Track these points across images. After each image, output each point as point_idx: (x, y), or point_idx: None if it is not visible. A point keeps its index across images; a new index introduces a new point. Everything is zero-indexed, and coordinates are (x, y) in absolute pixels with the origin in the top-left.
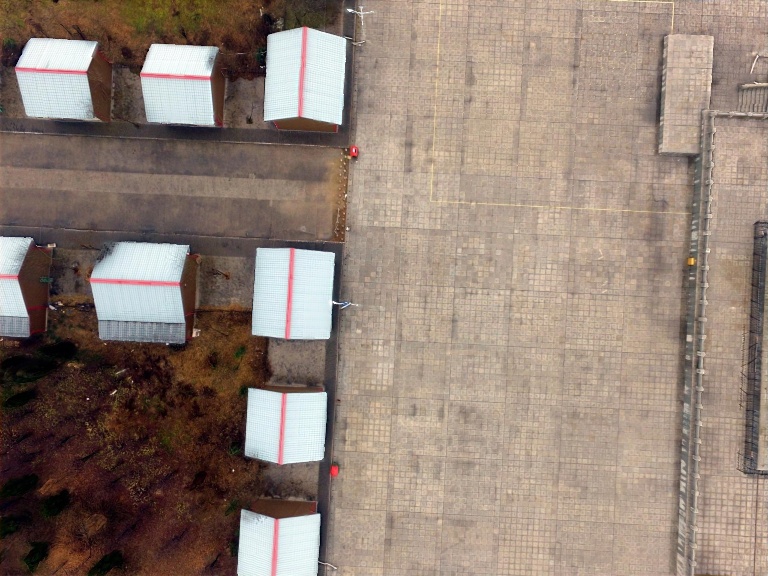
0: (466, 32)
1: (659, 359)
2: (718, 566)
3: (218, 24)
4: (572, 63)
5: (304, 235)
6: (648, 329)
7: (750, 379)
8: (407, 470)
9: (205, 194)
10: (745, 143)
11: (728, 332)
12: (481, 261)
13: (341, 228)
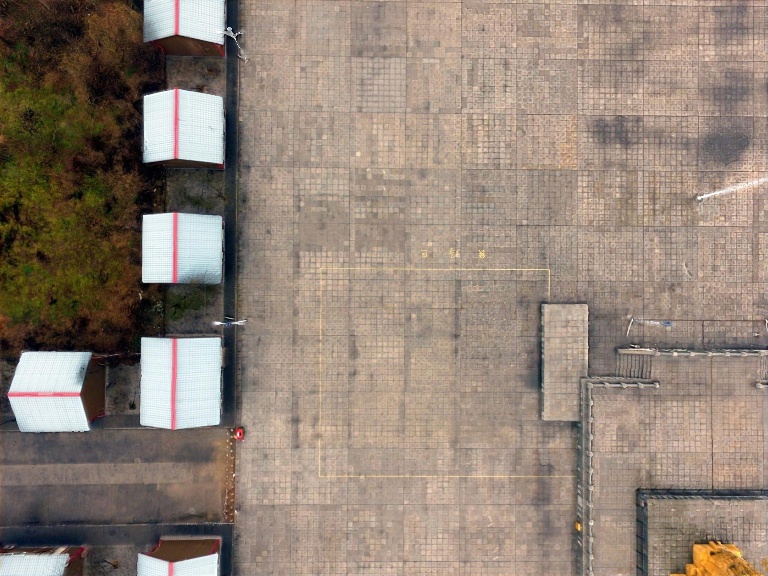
0: (347, 306)
1: None
2: None
3: (97, 310)
4: (453, 333)
5: (193, 518)
6: None
7: None
8: None
9: (90, 482)
10: (623, 411)
11: None
12: (372, 534)
13: (230, 510)
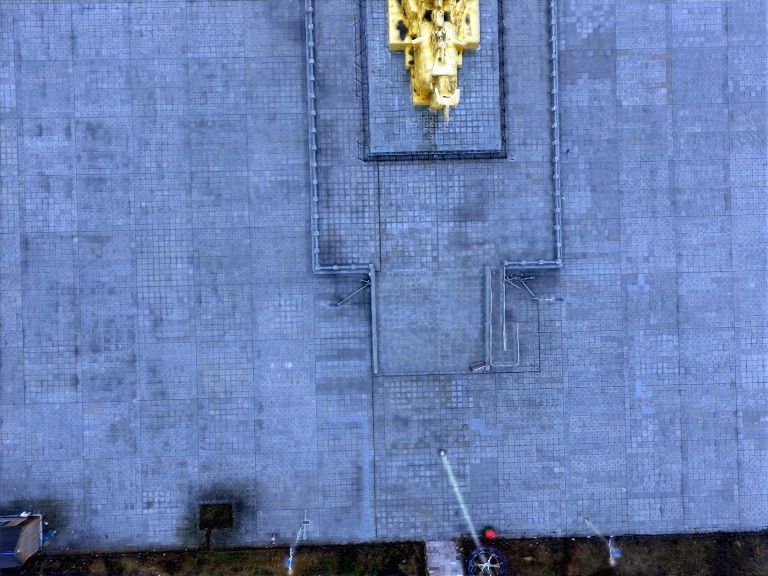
0: None
1: (282, 62)
2: (345, 254)
3: None
4: None
5: None
6: (269, 32)
7: (363, 68)
8: (38, 191)
9: None
10: None
11: (339, 23)
12: None
13: None
